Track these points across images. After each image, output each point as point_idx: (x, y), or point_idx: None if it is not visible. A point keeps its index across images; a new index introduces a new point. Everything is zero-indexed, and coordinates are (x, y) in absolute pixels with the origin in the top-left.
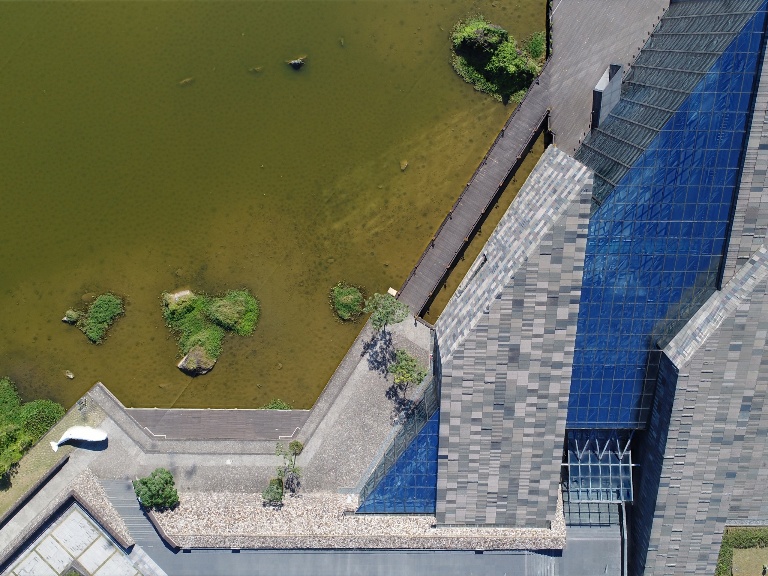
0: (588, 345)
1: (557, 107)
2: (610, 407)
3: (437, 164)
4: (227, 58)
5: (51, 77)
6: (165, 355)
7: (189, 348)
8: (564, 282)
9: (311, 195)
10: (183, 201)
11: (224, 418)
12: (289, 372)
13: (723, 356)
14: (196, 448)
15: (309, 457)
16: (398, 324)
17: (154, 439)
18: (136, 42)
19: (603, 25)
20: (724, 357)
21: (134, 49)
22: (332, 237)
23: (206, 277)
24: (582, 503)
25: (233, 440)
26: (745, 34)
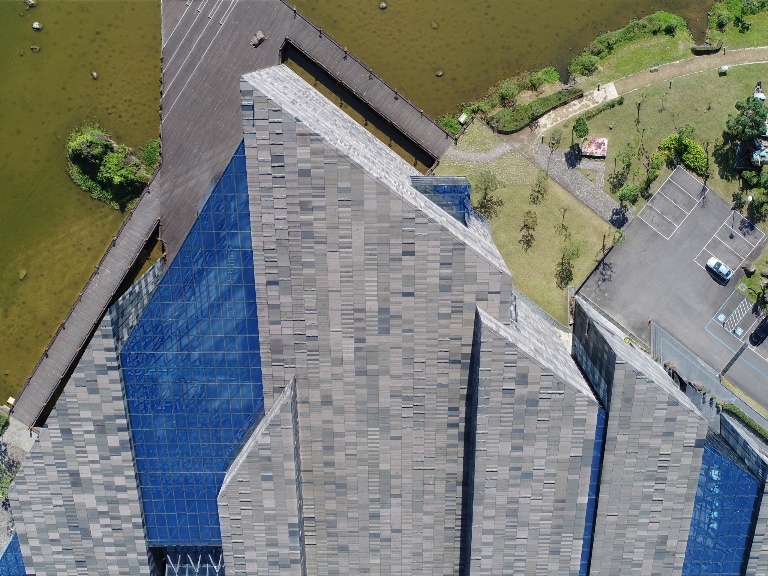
0: (152, 468)
1: (168, 216)
2: (189, 525)
3: (56, 273)
4: None
5: None
6: None
7: None
8: (107, 411)
9: None
10: None
11: None
12: None
13: (257, 486)
14: None
15: None
16: (13, 435)
17: None
18: None
19: (213, 133)
20: (258, 487)
21: None
22: None
23: None
24: None
25: None
26: (228, 177)
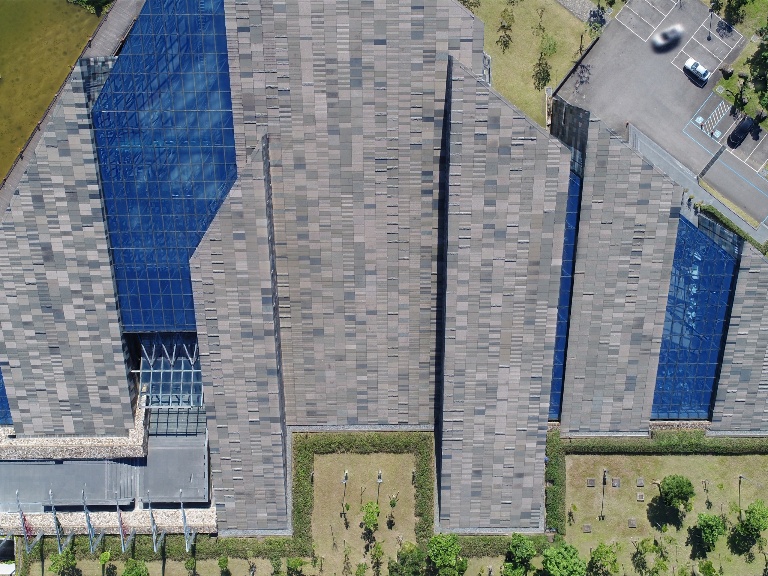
0: (126, 244)
1: None
2: (163, 309)
3: (31, 77)
4: None
5: None
6: None
7: None
8: (78, 176)
9: None
10: None
11: None
12: None
13: (230, 246)
14: None
15: None
16: None
17: None
18: None
19: None
20: (231, 247)
21: None
22: None
23: None
24: (172, 413)
25: None
26: None
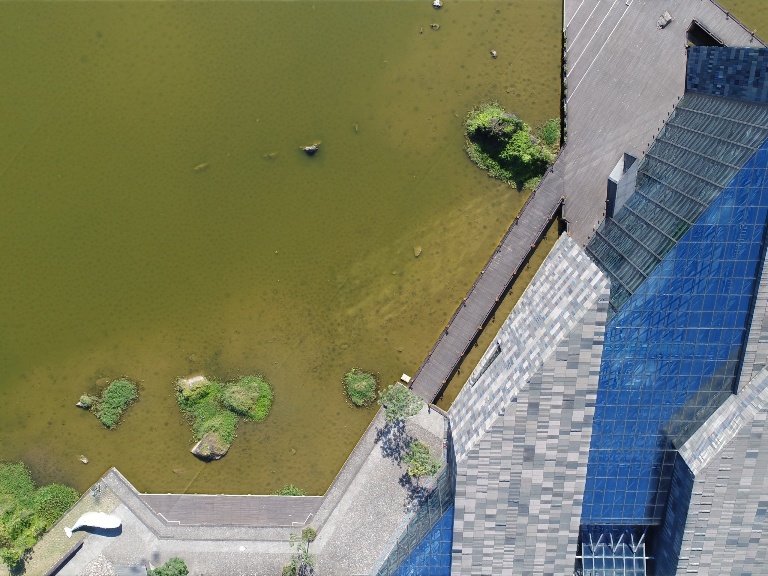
0: (603, 445)
1: (571, 195)
2: (625, 504)
3: (451, 250)
4: (241, 144)
5: (66, 162)
6: (179, 440)
7: (203, 434)
8: (580, 386)
9: (325, 281)
10: (197, 286)
11: (237, 504)
12: (302, 458)
13: (739, 463)
14: (209, 534)
15: (322, 544)
16: None
17: (168, 525)
18: (151, 128)
19: (618, 113)
20: (740, 464)
21: (149, 135)
22: (346, 323)
23: (220, 362)
24: None
25: (246, 526)
26: (763, 151)
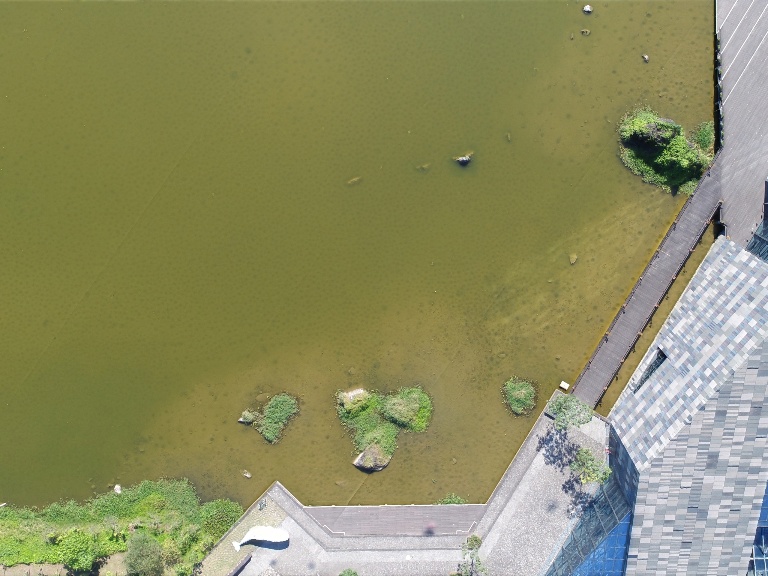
0: None
1: (729, 199)
2: None
3: (606, 257)
4: (394, 156)
5: (219, 180)
6: (340, 453)
7: (365, 446)
8: None
9: (481, 291)
10: (354, 300)
11: (401, 514)
12: (463, 467)
13: None
14: (375, 544)
15: (488, 551)
16: None
17: (334, 536)
18: (303, 143)
19: None
20: None
21: (301, 150)
22: (503, 332)
23: (379, 375)
24: None
25: (411, 536)
26: None
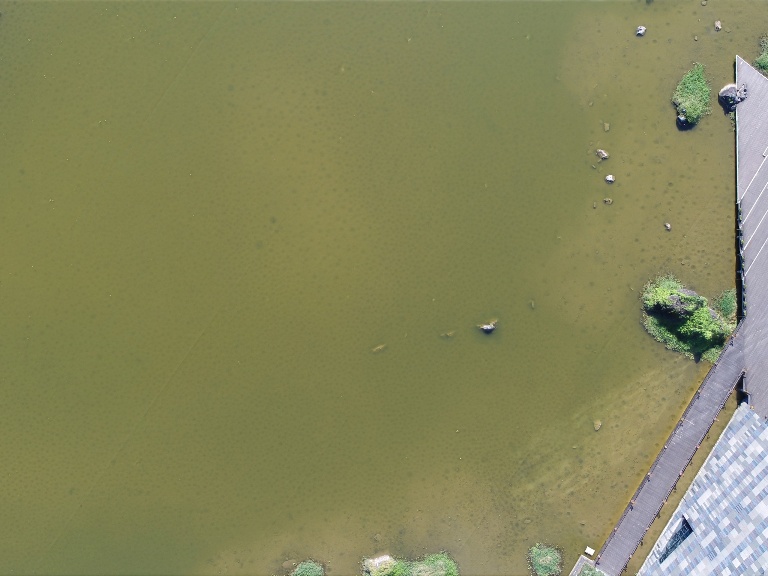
0: None
1: (752, 368)
2: None
3: (630, 423)
4: (418, 324)
5: (245, 348)
6: None
7: None
8: None
9: (506, 457)
10: (379, 467)
11: None
12: None
13: None
14: None
15: None
16: None
17: None
18: (328, 311)
19: None
20: None
21: (326, 318)
22: (528, 498)
23: (404, 541)
24: None
25: None
26: None
